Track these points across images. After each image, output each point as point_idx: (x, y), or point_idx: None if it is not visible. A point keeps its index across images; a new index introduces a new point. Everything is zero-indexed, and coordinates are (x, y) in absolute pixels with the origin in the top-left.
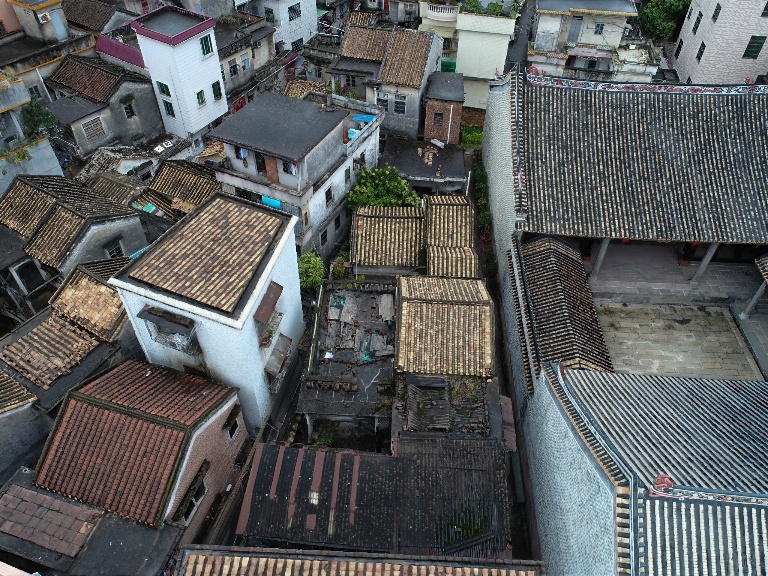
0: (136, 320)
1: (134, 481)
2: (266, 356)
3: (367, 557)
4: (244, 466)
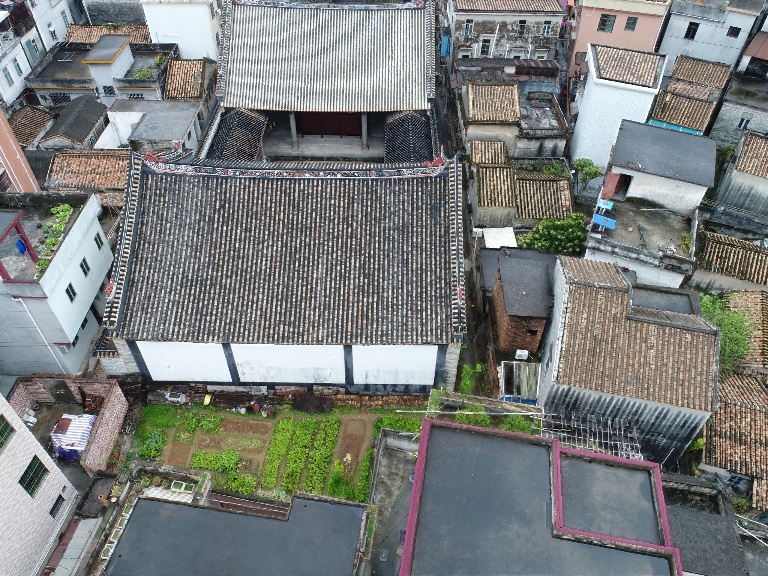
0: None
1: None
2: None
3: None
4: None
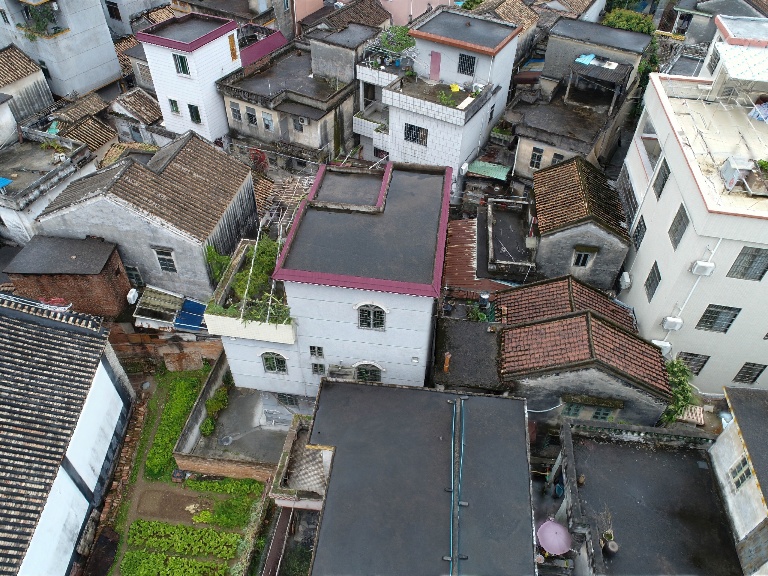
0: None
1: None
2: None
3: None
4: None
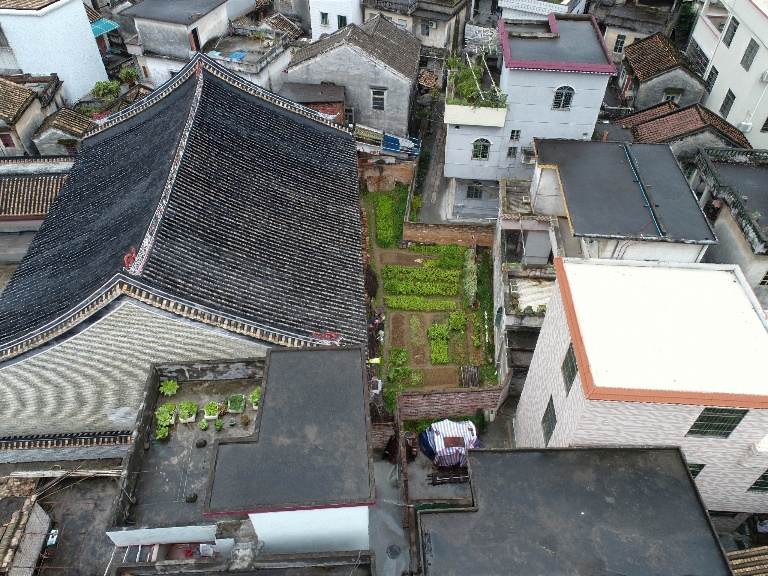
0: None
1: None
2: None
3: None
4: None
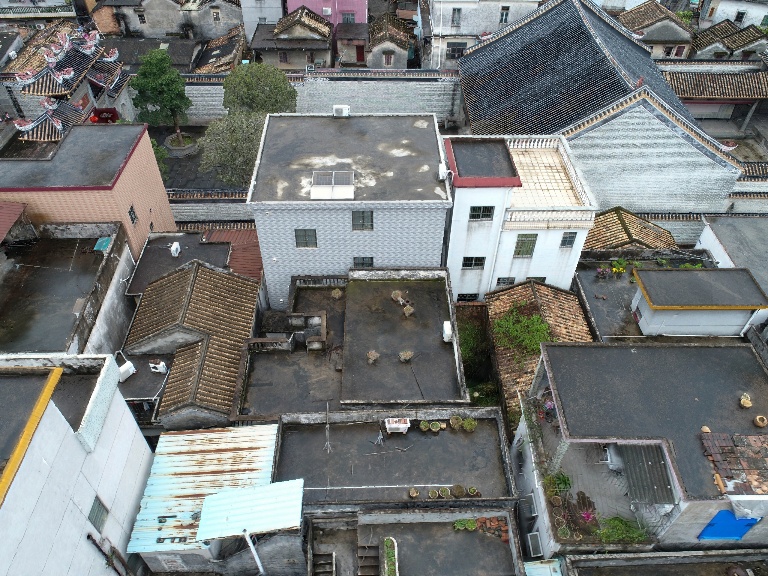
0: None
1: None
2: (608, 2)
3: None
4: None
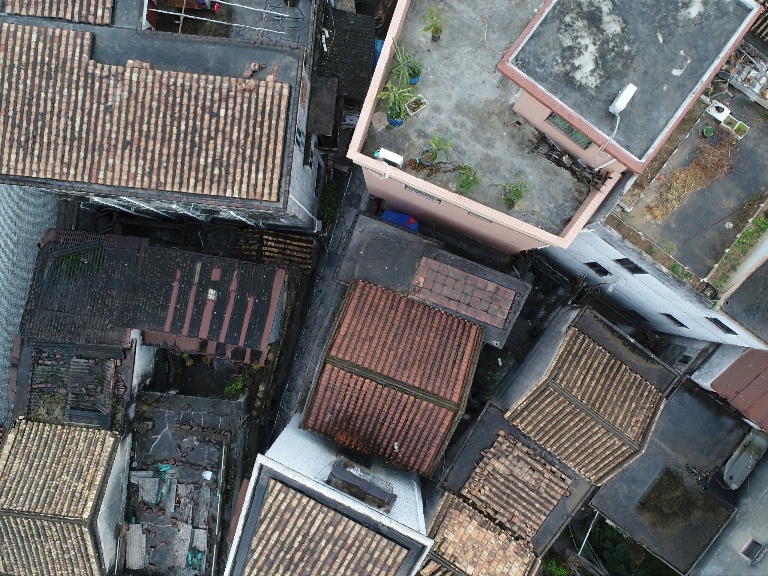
0: (415, 512)
1: (380, 317)
2: None
3: (127, 192)
4: (309, 365)
